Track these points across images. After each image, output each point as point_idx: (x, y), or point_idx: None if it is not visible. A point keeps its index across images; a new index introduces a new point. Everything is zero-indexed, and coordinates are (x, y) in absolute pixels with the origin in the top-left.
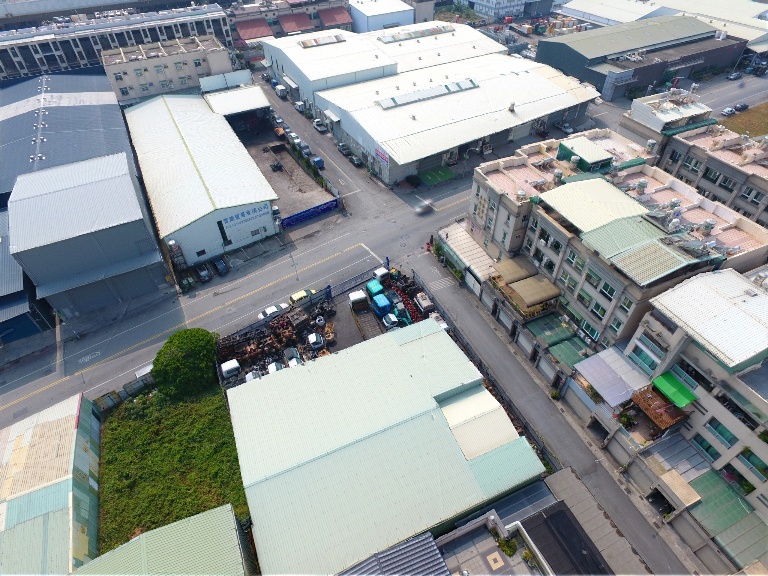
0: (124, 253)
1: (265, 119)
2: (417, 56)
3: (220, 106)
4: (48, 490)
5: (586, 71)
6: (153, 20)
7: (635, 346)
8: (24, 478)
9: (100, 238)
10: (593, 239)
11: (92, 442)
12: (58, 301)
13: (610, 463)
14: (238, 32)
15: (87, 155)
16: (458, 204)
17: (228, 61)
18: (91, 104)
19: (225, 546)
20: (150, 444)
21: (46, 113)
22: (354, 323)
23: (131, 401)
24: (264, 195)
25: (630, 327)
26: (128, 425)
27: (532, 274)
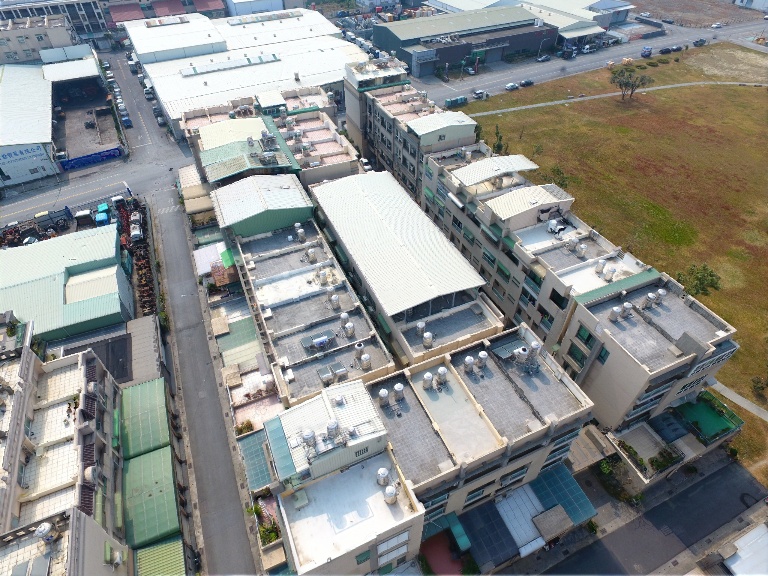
0: None
1: (102, 88)
2: (253, 36)
3: (52, 74)
4: None
5: (401, 51)
6: (26, 2)
7: None
8: None
9: None
10: (206, 155)
11: None
12: None
13: None
14: (111, 15)
15: None
16: None
17: (67, 36)
18: None
19: None
20: None
21: None
22: None
23: None
24: (39, 139)
25: None
26: None
27: None
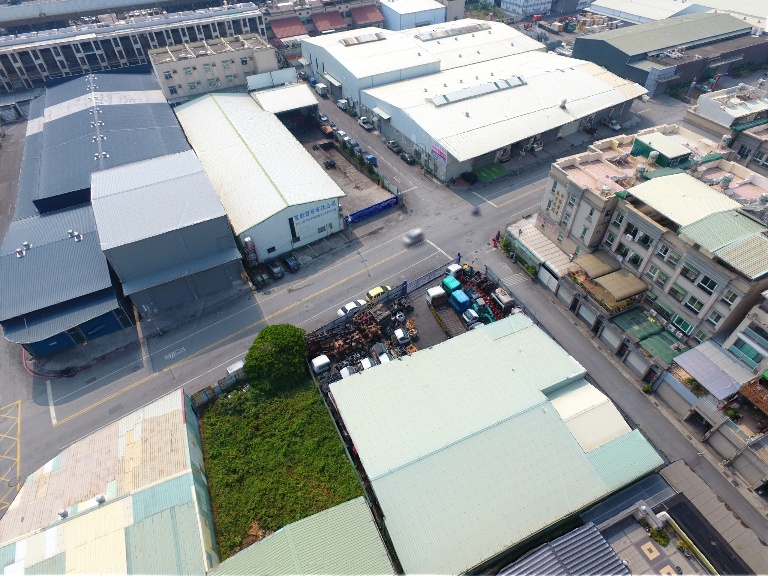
0: (205, 250)
1: (311, 117)
2: (457, 54)
3: (269, 104)
4: (170, 484)
5: (627, 68)
6: (191, 19)
7: (736, 339)
8: (144, 472)
9: (185, 235)
10: (693, 233)
11: (196, 437)
12: (140, 298)
13: (713, 456)
14: (273, 31)
15: (149, 153)
16: (517, 201)
17: (275, 59)
18: (141, 103)
19: (367, 538)
20: (252, 439)
21: (100, 112)
22: (433, 319)
23: (226, 396)
24: (331, 192)
25: (732, 320)
26: (226, 420)
27: (615, 269)
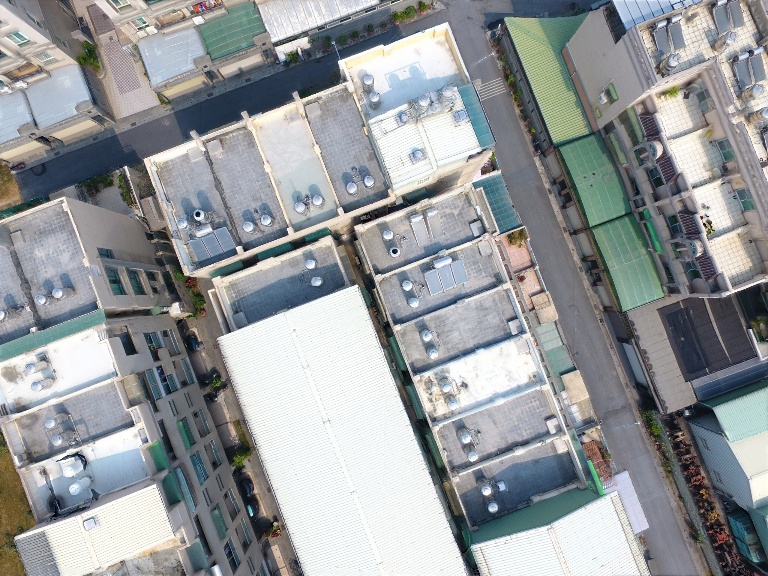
0: None
1: None
2: None
3: None
4: None
5: None
6: None
7: None
8: None
9: None
10: None
11: None
12: None
13: None
14: None
15: None
16: None
17: None
18: None
19: None
20: None
21: None
22: None
23: None
24: None
25: None
26: None
27: None
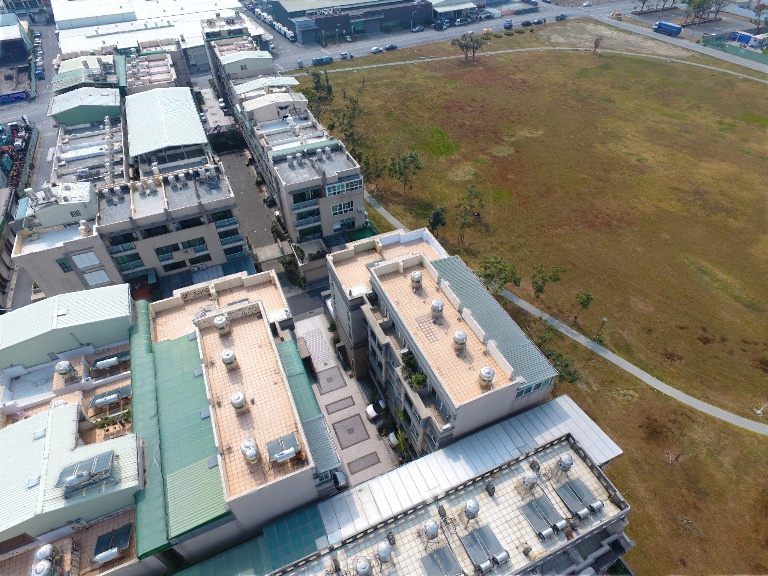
0: None
1: (26, 50)
2: (162, 9)
3: None
4: None
5: (289, 22)
6: None
7: None
8: None
9: None
10: (57, 76)
11: None
12: None
13: None
14: None
15: None
16: None
17: None
18: None
19: None
20: None
21: None
22: None
23: None
24: None
25: None
26: None
27: None
